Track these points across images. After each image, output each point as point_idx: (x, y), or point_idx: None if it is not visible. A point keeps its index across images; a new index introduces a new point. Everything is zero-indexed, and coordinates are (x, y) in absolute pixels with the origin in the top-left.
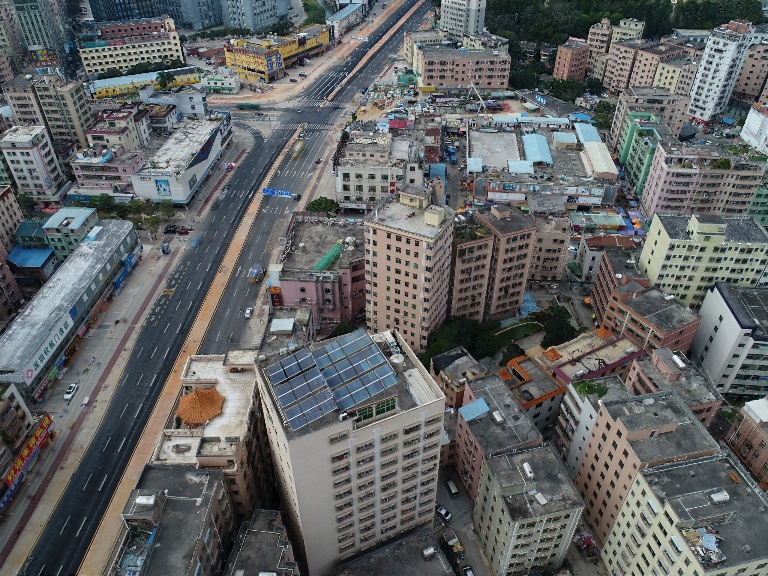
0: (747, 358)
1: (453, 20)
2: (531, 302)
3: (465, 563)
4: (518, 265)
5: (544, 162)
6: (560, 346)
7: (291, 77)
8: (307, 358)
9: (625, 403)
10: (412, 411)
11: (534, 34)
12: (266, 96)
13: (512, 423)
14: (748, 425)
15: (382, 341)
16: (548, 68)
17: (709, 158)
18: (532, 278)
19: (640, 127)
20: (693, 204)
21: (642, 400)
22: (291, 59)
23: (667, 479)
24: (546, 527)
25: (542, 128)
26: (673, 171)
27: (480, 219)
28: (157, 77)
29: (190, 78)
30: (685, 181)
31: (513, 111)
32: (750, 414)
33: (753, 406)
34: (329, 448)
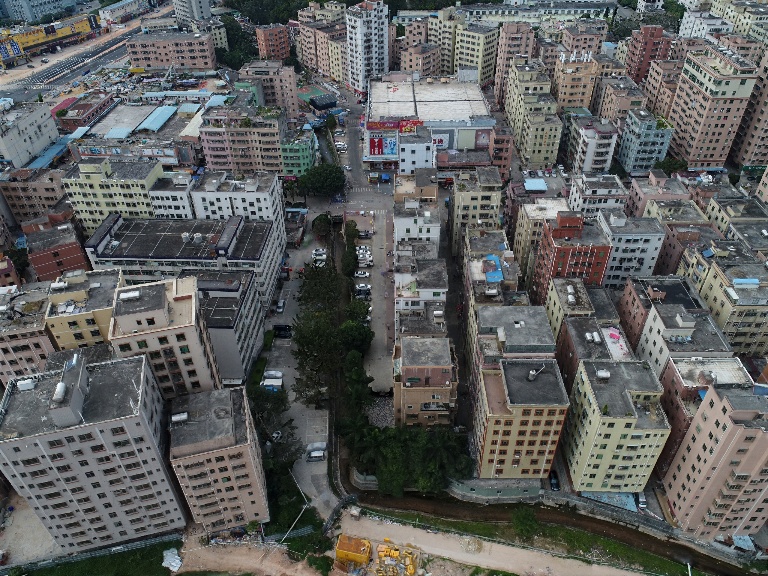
0: None
1: (181, 6)
2: None
3: None
4: None
5: (149, 129)
6: None
7: None
8: None
9: None
10: None
11: (275, 18)
12: None
13: None
14: None
15: None
16: None
17: (237, 118)
18: None
19: None
20: (236, 160)
21: None
22: (39, 47)
23: None
24: None
25: (188, 101)
26: (204, 130)
27: None
28: None
29: None
30: (218, 139)
31: (205, 88)
32: None
33: None
34: None
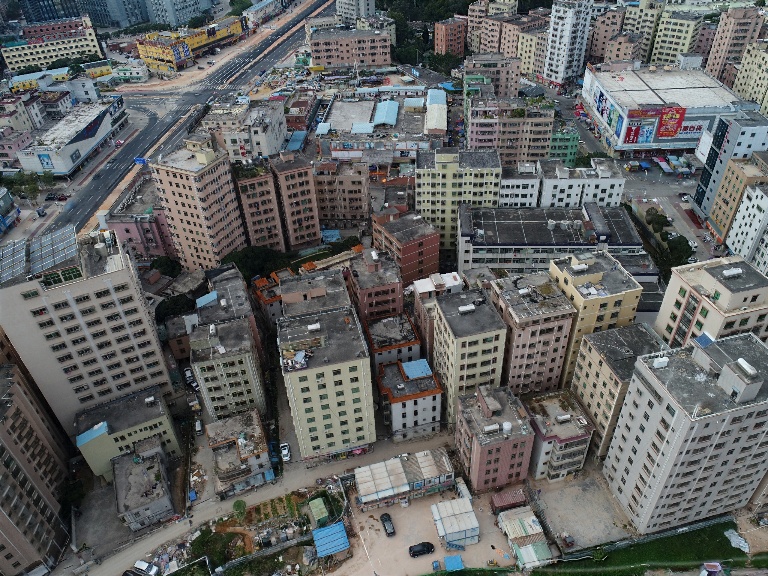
0: (473, 262)
1: (346, 5)
2: (337, 236)
3: (201, 418)
4: (304, 200)
5: (387, 124)
6: (323, 261)
7: (200, 65)
8: (21, 244)
9: (300, 280)
10: (95, 278)
11: (429, 14)
12: (171, 83)
13: (236, 308)
14: (416, 299)
15: (95, 236)
16: (434, 45)
17: (508, 109)
18: (344, 218)
19: (468, 88)
20: (501, 151)
21: (315, 278)
22: (201, 49)
23: (297, 324)
24: (227, 372)
25: (401, 96)
26: (476, 122)
27: (270, 163)
28: (68, 70)
29: (103, 70)
30: (489, 130)
31: (391, 84)
32: (416, 290)
33: (418, 283)
34: (26, 304)
